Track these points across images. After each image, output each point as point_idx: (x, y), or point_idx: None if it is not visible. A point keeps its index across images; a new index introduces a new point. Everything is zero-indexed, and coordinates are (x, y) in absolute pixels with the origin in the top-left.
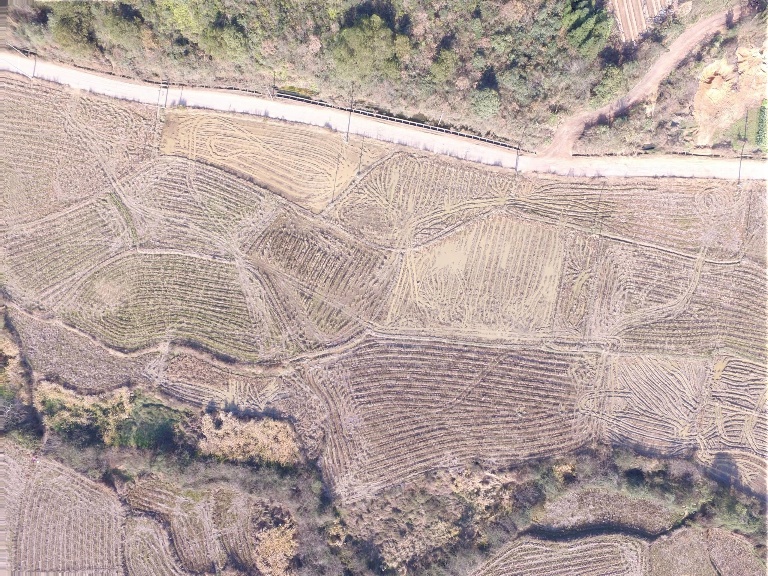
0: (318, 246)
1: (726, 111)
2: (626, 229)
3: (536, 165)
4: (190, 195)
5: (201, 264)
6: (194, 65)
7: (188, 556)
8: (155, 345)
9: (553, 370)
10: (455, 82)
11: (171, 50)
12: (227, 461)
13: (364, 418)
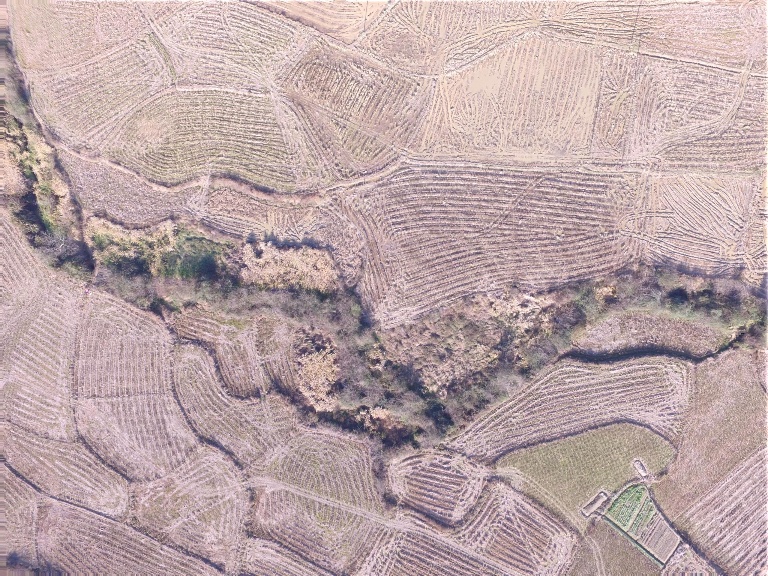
0: (351, 76)
1: None
2: (666, 45)
3: None
4: (225, 32)
5: (237, 99)
6: None
7: (234, 382)
8: (196, 178)
9: (592, 192)
10: None
11: None
12: (268, 289)
13: (401, 245)
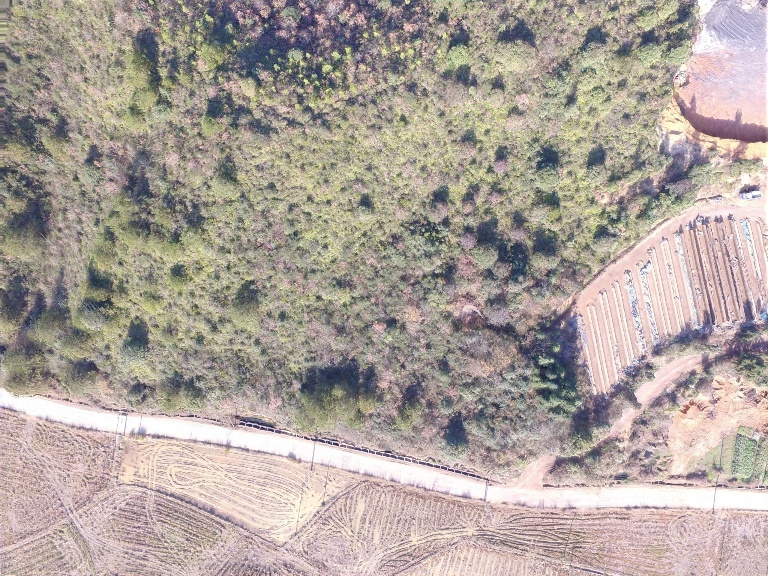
0: None
1: (701, 439)
2: (597, 560)
3: (505, 496)
4: (149, 526)
5: None
6: (152, 405)
7: None
8: None
9: None
10: (421, 431)
11: (127, 399)
12: None
13: None
